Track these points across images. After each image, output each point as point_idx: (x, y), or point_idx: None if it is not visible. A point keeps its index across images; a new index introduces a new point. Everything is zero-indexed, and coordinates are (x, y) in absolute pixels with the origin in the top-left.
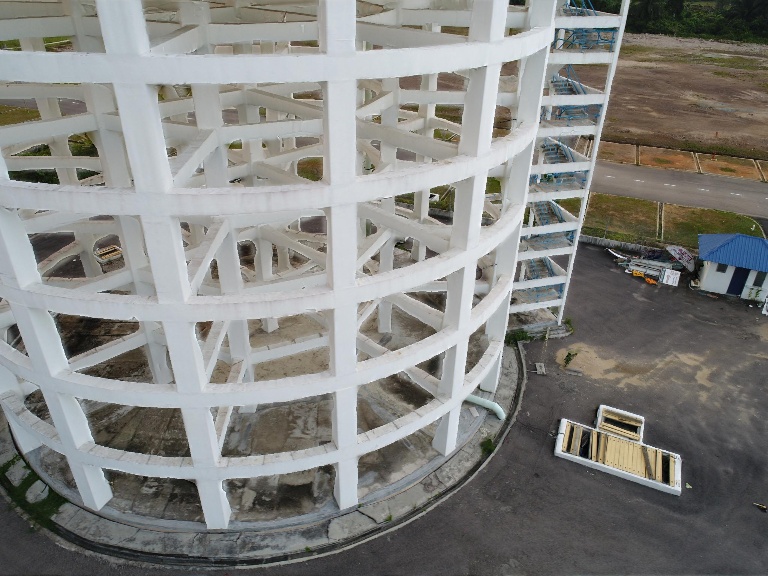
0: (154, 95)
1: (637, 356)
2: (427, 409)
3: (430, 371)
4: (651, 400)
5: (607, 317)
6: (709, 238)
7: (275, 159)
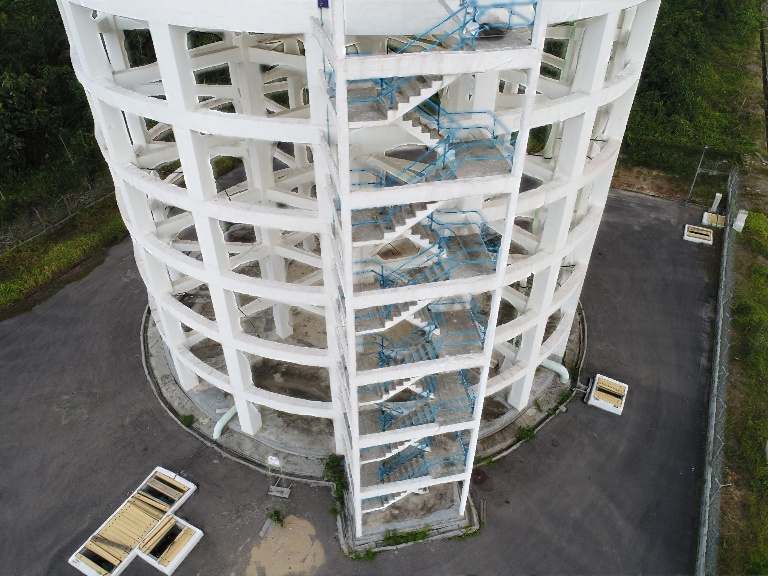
0: (108, 36)
1: None
2: None
3: (289, 389)
4: None
5: None
6: None
7: (374, 160)
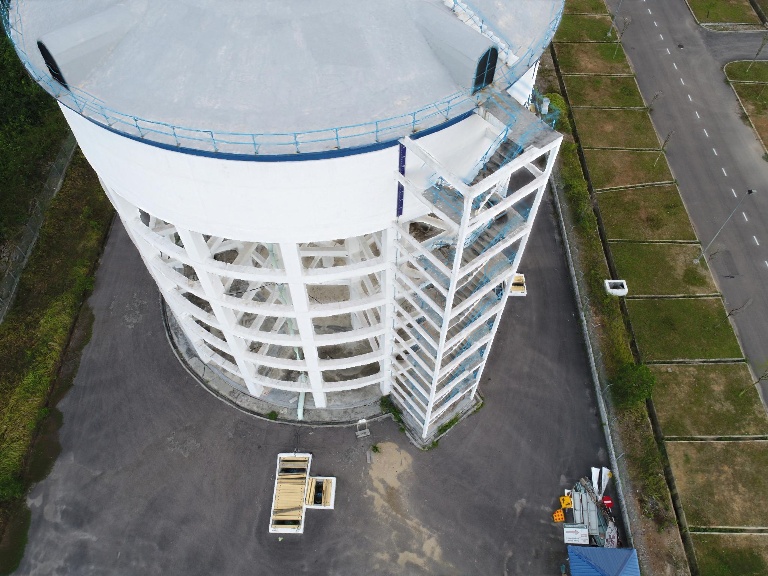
0: None
1: (414, 503)
2: (229, 365)
3: None
4: (360, 515)
5: (464, 477)
6: (617, 556)
7: None
